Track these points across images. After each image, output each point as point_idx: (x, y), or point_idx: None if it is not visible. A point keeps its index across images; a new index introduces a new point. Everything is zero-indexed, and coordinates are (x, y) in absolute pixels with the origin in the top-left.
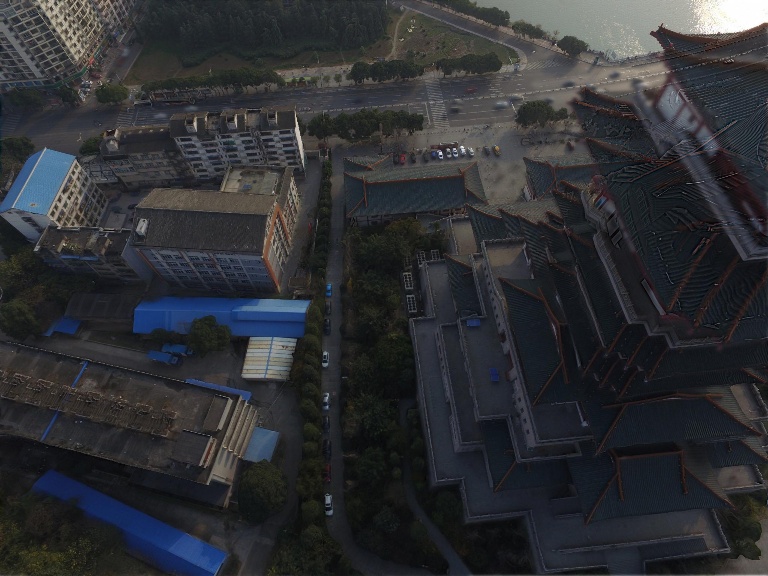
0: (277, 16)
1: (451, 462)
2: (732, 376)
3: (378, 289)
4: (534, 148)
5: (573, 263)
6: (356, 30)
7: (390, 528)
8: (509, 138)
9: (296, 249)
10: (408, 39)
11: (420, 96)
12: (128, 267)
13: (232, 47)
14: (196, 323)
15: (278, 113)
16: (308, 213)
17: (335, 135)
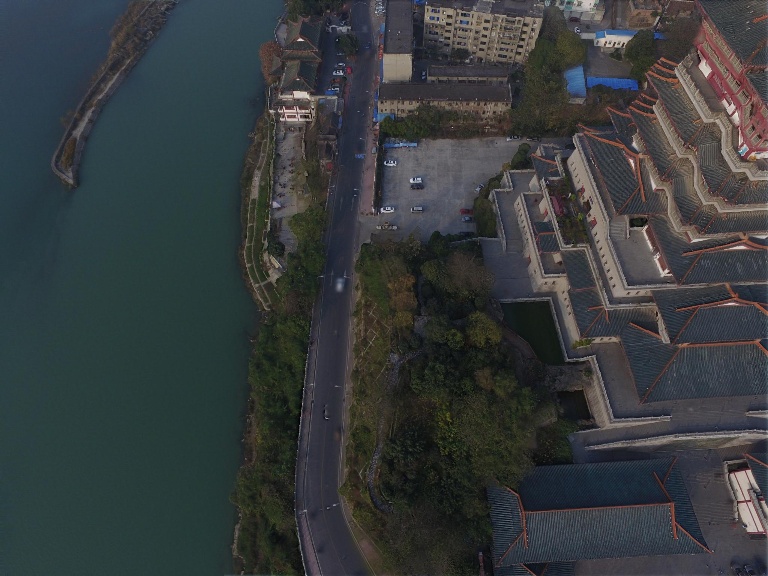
0: None
1: None
2: None
3: None
4: None
5: None
6: None
7: None
8: None
9: None
10: None
11: None
12: None
13: None
14: None
15: None
16: None
17: None
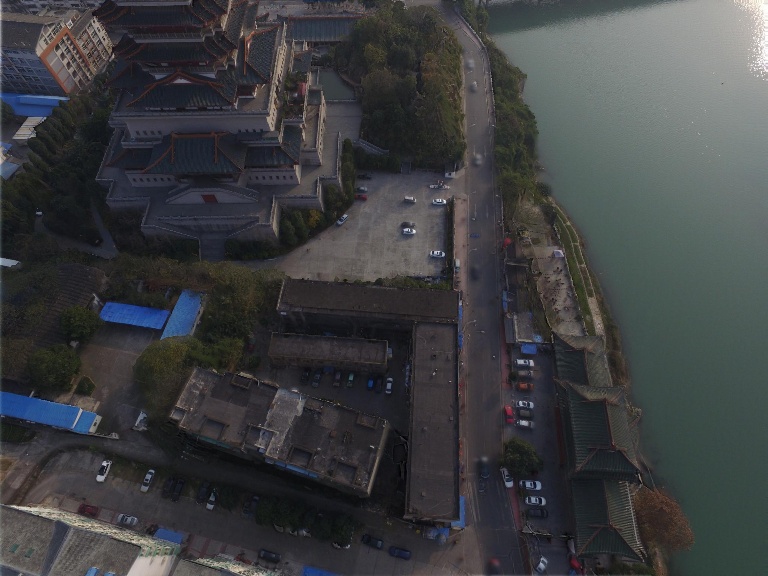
0: None
1: (113, 173)
2: (202, 55)
3: None
4: None
5: None
6: None
7: (59, 207)
8: None
9: None
10: None
11: None
12: None
13: None
14: None
15: None
16: None
17: None
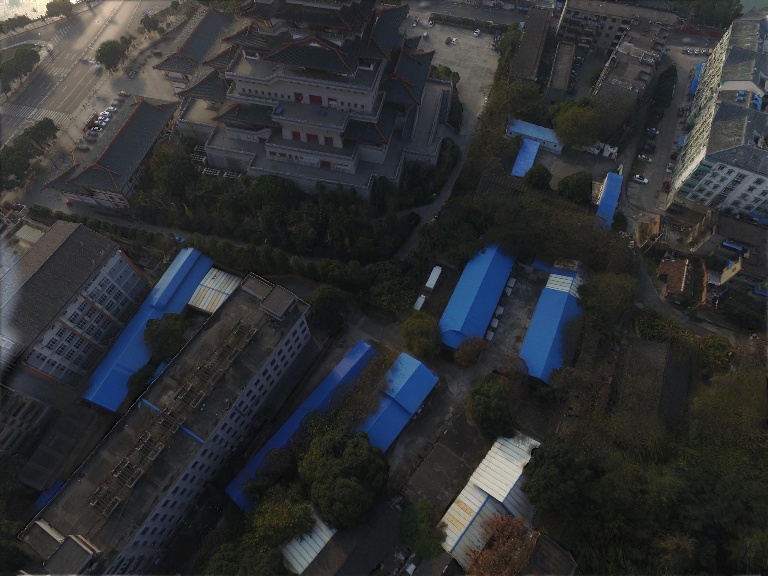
0: None
1: (359, 178)
2: None
3: (207, 187)
4: (141, 73)
5: (282, 5)
6: None
7: (384, 226)
8: (118, 83)
9: None
10: None
11: (13, 122)
12: (28, 403)
13: None
14: (150, 329)
15: None
16: None
17: (2, 194)
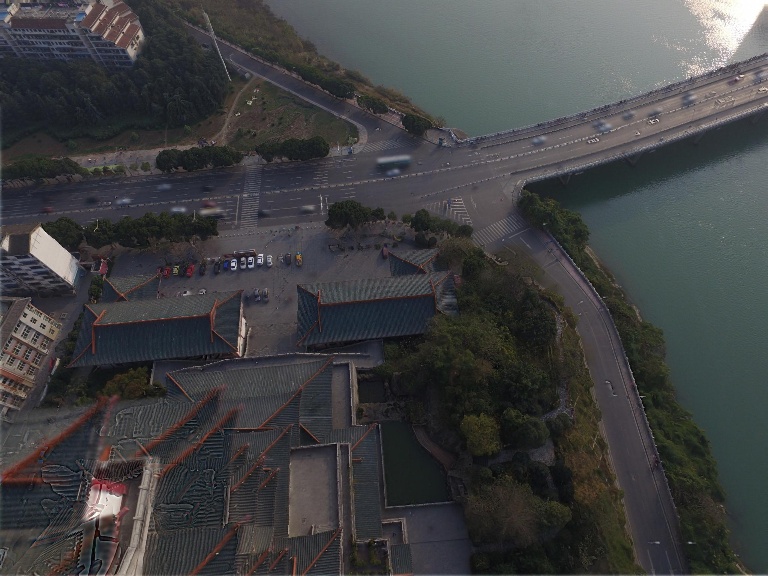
0: (92, 93)
1: None
2: None
3: None
4: (343, 256)
5: None
6: (179, 108)
7: None
8: (319, 242)
9: (37, 390)
10: (244, 113)
11: (235, 187)
12: None
13: (48, 126)
14: None
15: (11, 236)
16: (56, 346)
17: None
